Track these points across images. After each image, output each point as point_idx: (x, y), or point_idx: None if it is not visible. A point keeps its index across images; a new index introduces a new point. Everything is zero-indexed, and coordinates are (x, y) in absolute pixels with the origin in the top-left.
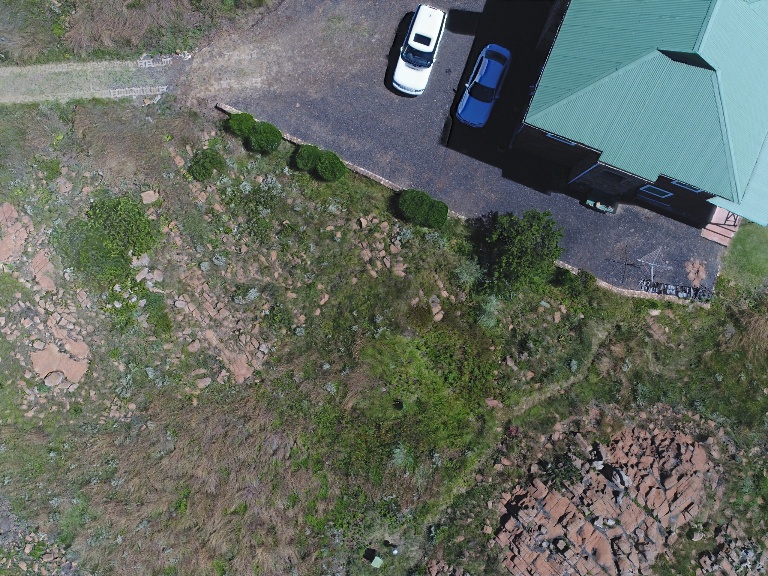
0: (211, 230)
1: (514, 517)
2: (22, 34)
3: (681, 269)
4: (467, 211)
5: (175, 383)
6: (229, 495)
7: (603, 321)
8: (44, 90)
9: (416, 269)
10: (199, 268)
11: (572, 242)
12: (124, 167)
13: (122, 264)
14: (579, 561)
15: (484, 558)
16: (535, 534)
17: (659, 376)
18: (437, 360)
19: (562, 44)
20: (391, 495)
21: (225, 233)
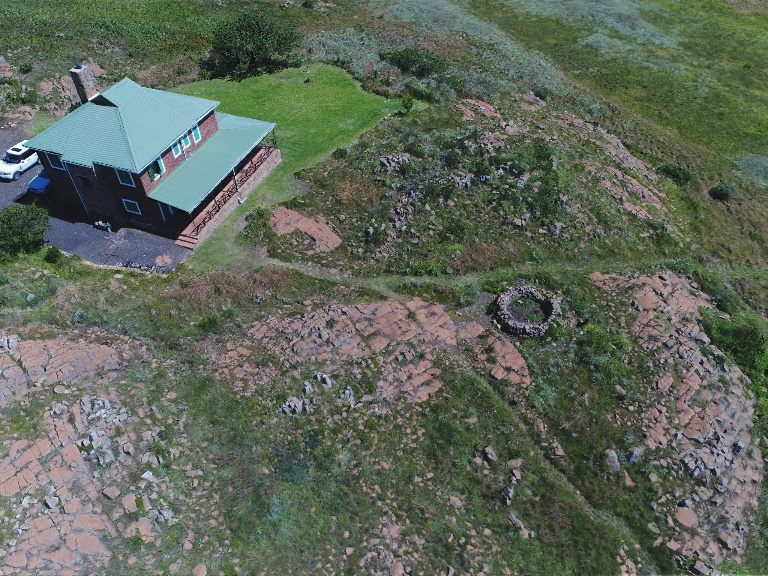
0: None
1: None
2: None
3: (153, 258)
4: None
5: None
6: None
7: (75, 281)
8: None
9: None
10: None
11: (78, 245)
12: None
13: None
14: None
15: None
16: None
17: (103, 310)
18: None
19: None
20: None
21: None
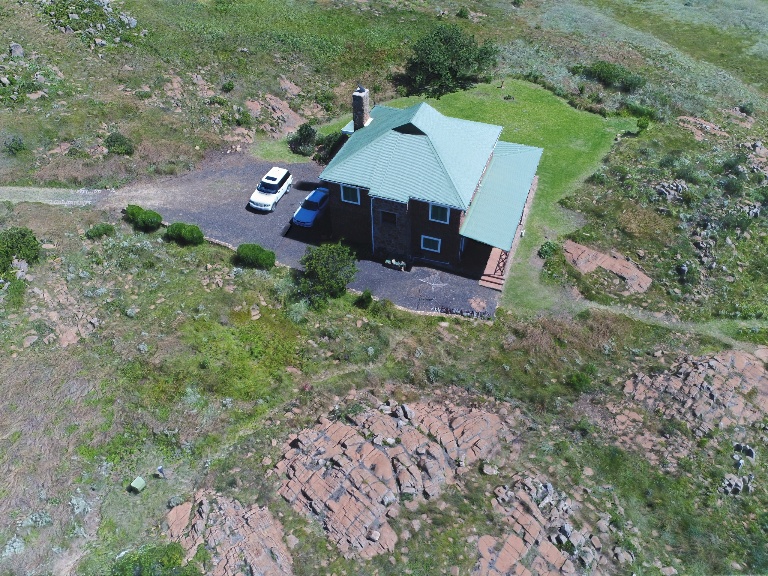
0: (86, 262)
1: (296, 447)
2: (6, 169)
3: (465, 302)
4: (294, 267)
5: (4, 341)
6: (8, 423)
7: (400, 330)
8: (4, 197)
9: (243, 289)
10: (66, 280)
11: (376, 286)
12: (38, 229)
13: (4, 259)
14: (354, 469)
15: (258, 486)
16: (312, 453)
17: (451, 365)
18: (247, 341)
19: (345, 147)
20: (174, 430)
21: (97, 265)
